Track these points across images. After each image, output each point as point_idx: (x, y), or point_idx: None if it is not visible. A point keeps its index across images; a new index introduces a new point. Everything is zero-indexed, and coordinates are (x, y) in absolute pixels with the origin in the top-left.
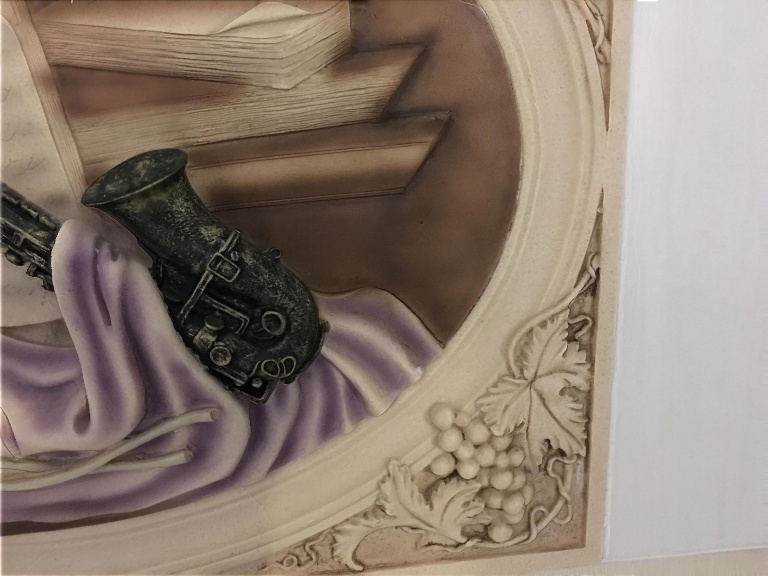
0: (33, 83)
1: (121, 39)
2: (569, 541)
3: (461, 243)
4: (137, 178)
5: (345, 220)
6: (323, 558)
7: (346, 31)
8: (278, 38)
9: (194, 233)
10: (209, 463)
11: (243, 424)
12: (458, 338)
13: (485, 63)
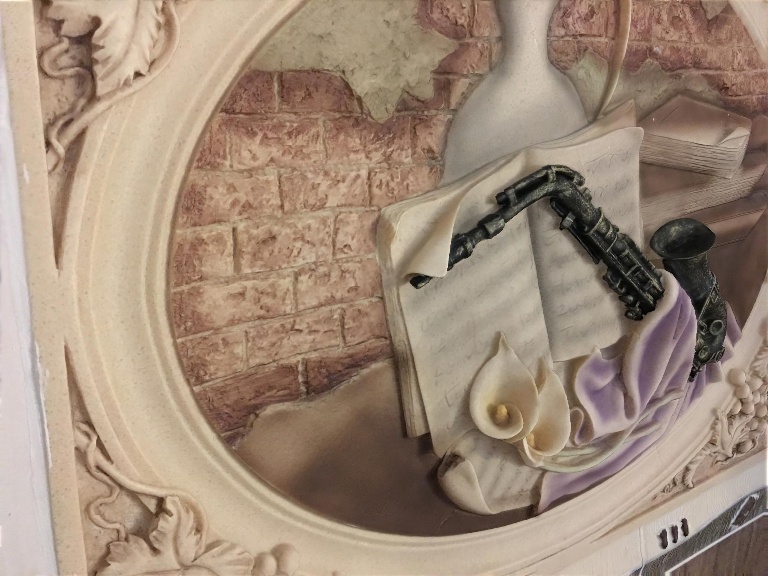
0: (638, 175)
1: (672, 146)
2: (760, 445)
3: (754, 268)
4: (670, 238)
5: (723, 258)
6: None
7: None
8: (738, 148)
9: None
10: None
11: None
12: (746, 327)
13: None
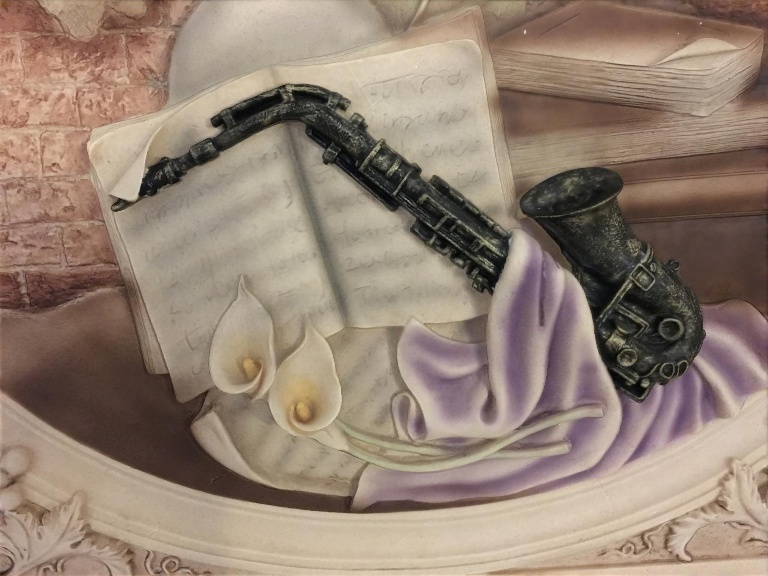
0: (487, 105)
1: (564, 67)
2: None
3: None
4: (564, 193)
5: (725, 236)
6: (656, 548)
7: (758, 65)
8: (708, 70)
9: (622, 245)
10: (576, 455)
11: (618, 420)
12: None
13: None
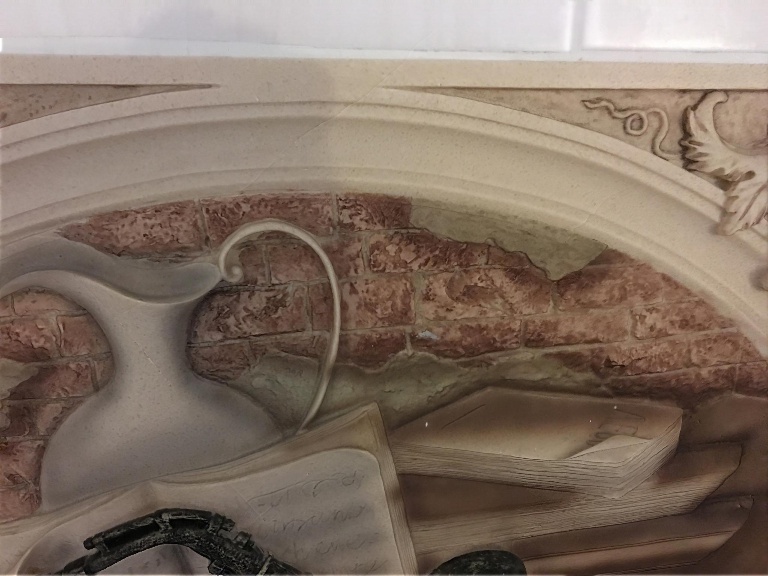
0: (386, 500)
1: (469, 457)
2: None
3: None
4: (469, 575)
5: None
6: None
7: (675, 442)
8: (620, 462)
9: None
10: None
11: None
12: None
13: None
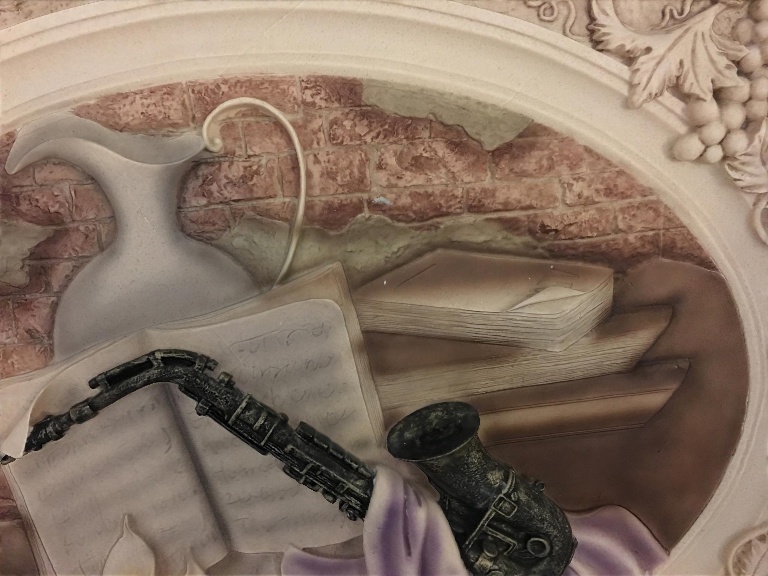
0: (351, 351)
1: (424, 313)
2: None
3: (689, 466)
4: (429, 426)
5: (593, 450)
6: None
7: (609, 300)
8: (558, 314)
9: (483, 479)
10: None
11: None
12: (681, 545)
13: (722, 319)
